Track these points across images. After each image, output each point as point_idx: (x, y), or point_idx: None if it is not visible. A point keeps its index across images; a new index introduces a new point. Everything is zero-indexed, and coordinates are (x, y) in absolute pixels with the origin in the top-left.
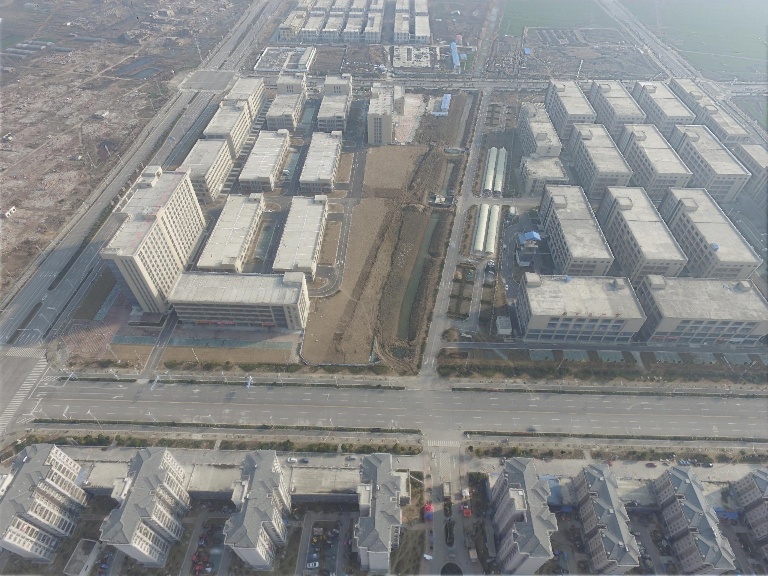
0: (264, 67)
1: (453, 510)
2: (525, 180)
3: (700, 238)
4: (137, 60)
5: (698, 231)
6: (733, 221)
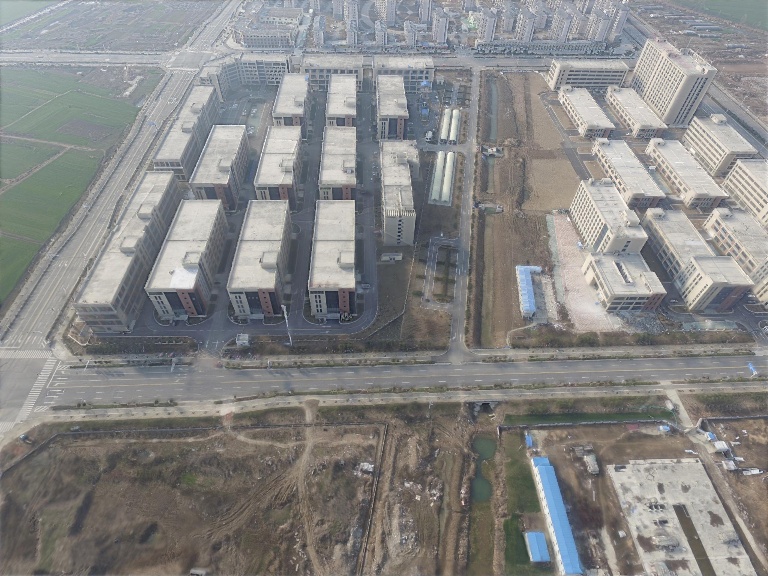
0: None
1: (459, 45)
2: None
3: None
4: None
5: None
6: None
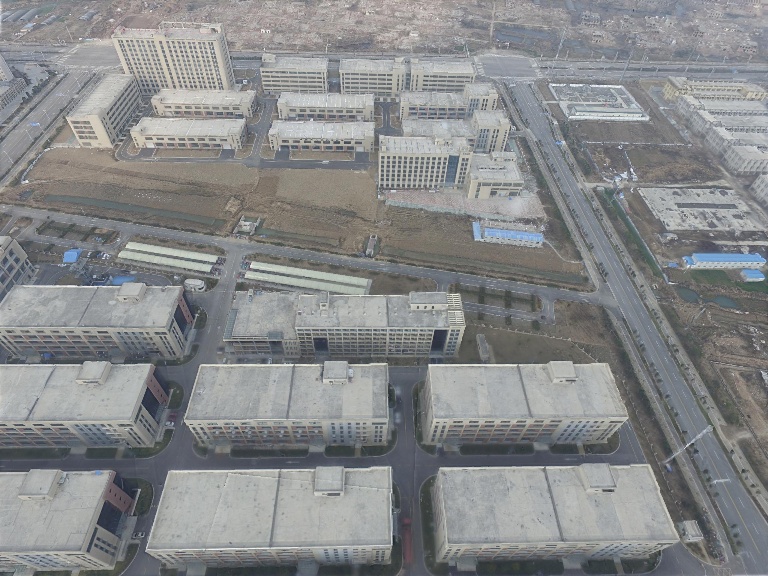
0: None
1: None
2: None
3: None
4: (539, 31)
5: None
6: None
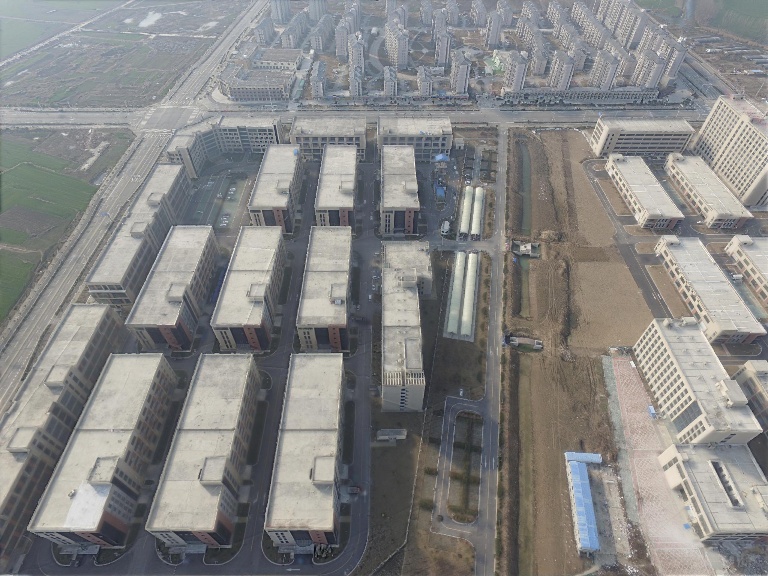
0: None
1: None
2: None
3: None
4: None
5: None
6: (215, 226)
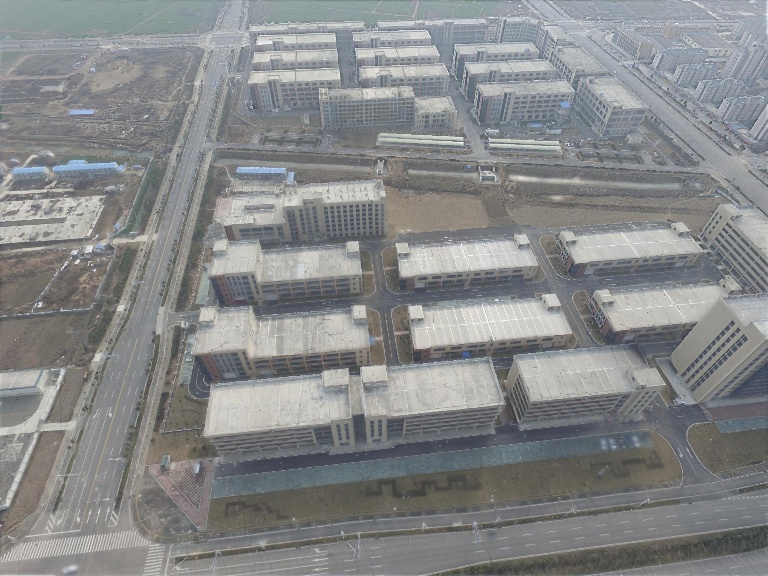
0: (0, 480)
1: None
2: (444, 121)
3: (515, 55)
4: None
5: (510, 53)
6: None
